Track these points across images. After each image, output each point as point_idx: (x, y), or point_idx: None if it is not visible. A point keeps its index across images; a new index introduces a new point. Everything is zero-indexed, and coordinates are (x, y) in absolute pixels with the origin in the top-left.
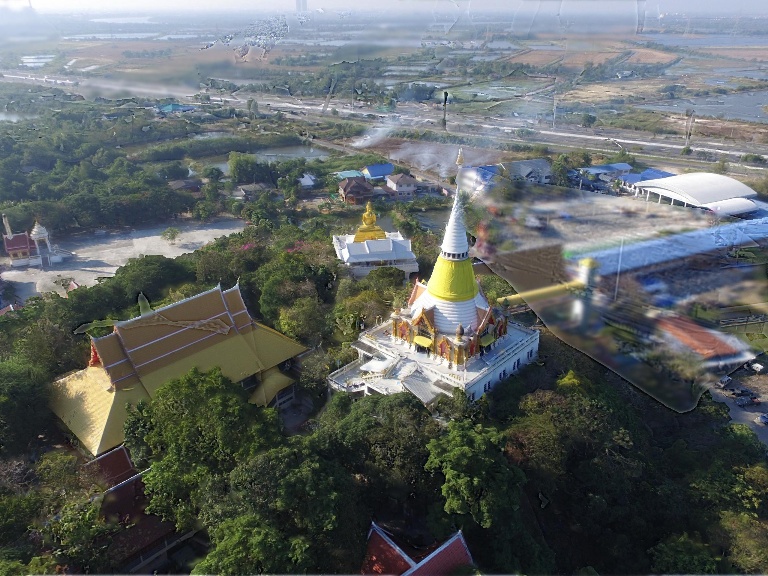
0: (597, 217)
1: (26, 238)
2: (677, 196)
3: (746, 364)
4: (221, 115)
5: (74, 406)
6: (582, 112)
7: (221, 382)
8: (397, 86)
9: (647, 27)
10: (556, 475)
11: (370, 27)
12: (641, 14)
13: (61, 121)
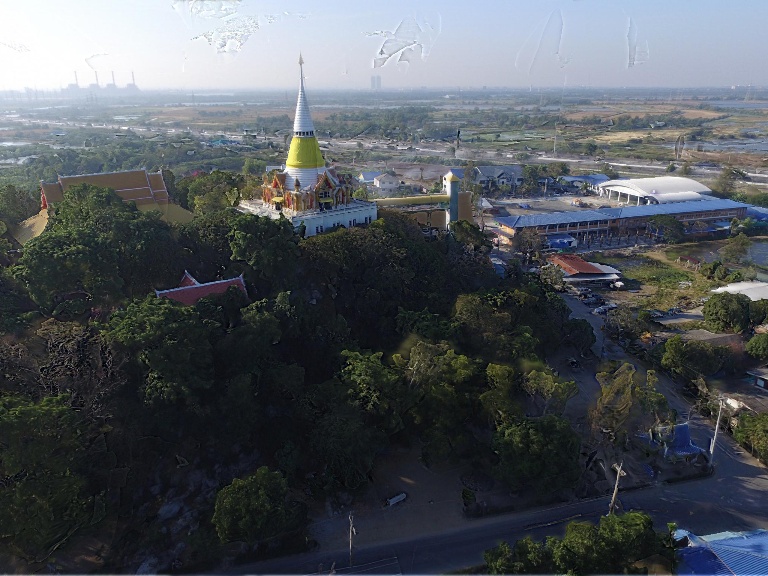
0: None
1: None
2: (632, 191)
3: (612, 284)
4: (260, 147)
5: (25, 231)
6: None
7: (108, 191)
8: (425, 128)
9: (638, 60)
10: (338, 267)
11: (356, 46)
12: (632, 49)
13: (123, 148)
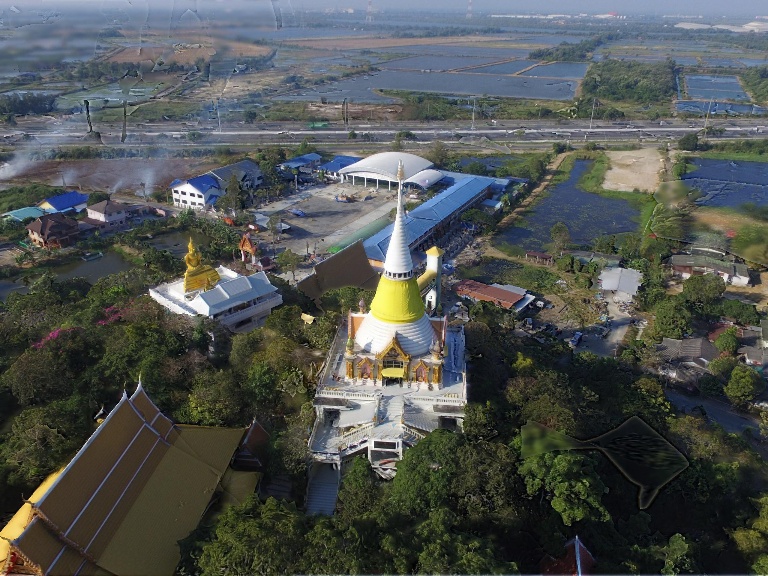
0: None
1: None
2: (381, 176)
3: (530, 304)
4: None
5: None
6: (230, 109)
7: None
8: (3, 98)
9: (285, 23)
10: None
11: (25, 29)
12: (277, 10)
13: None
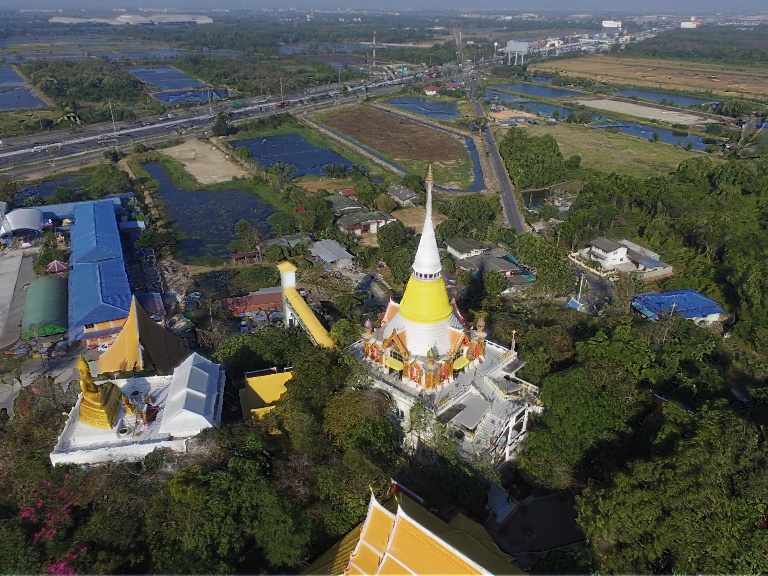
0: None
1: None
2: None
3: None
4: None
5: None
6: None
7: None
8: None
9: None
10: None
11: None
12: None
13: None
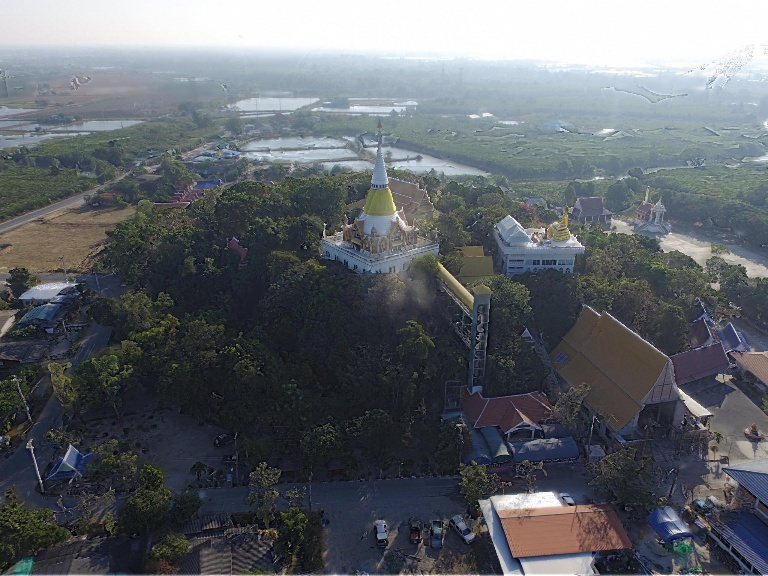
0: (166, 82)
1: (650, 207)
2: None
3: None
4: None
5: None
6: None
7: None
8: None
9: None
10: None
11: None
12: None
13: None
